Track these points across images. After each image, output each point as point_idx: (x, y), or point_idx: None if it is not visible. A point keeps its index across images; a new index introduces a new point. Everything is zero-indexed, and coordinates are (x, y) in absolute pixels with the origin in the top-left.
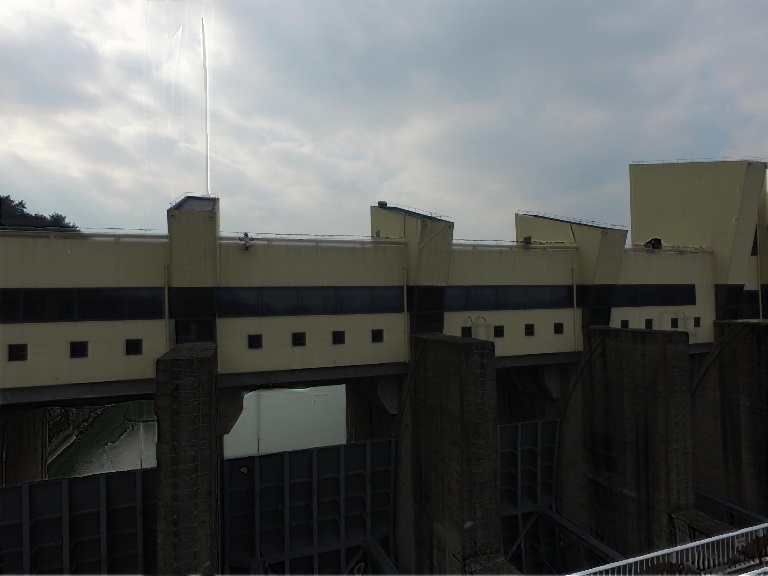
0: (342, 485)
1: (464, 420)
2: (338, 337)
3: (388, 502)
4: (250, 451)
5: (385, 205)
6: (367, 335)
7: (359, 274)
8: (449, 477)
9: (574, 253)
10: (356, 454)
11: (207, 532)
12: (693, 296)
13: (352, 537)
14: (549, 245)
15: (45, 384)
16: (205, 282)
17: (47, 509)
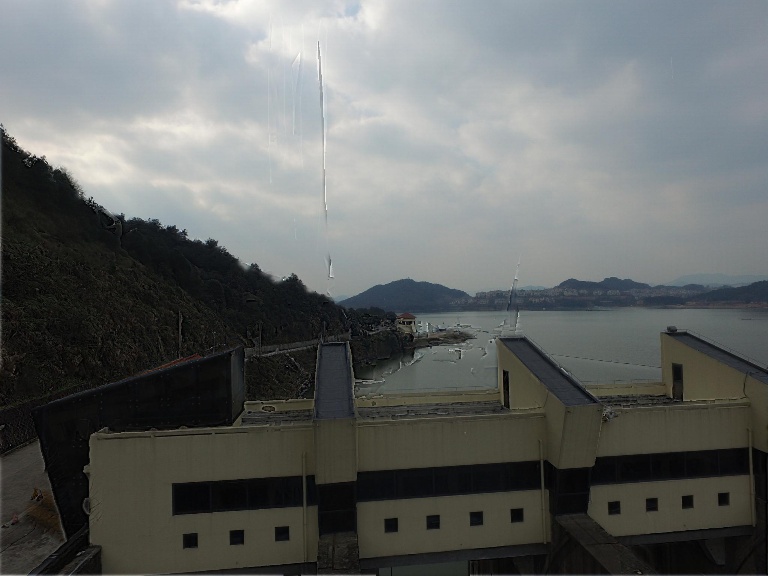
0: None
1: None
2: (686, 501)
3: None
4: None
5: (675, 331)
6: (714, 499)
7: (704, 438)
8: None
9: None
10: None
11: None
12: None
13: None
14: None
15: (453, 549)
16: (585, 463)
17: None
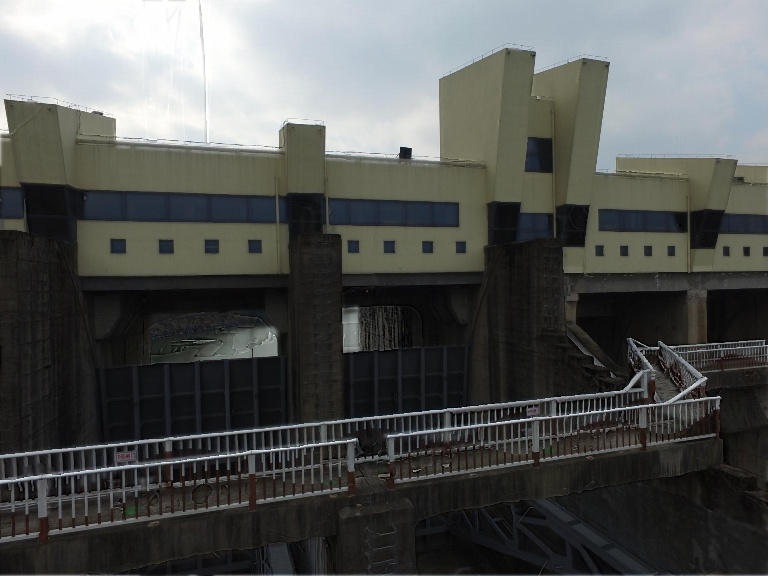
0: None
1: None
2: None
3: None
4: None
5: None
6: None
7: None
8: None
9: (279, 159)
10: None
11: None
12: (456, 217)
13: None
14: (242, 148)
15: None
16: None
17: None
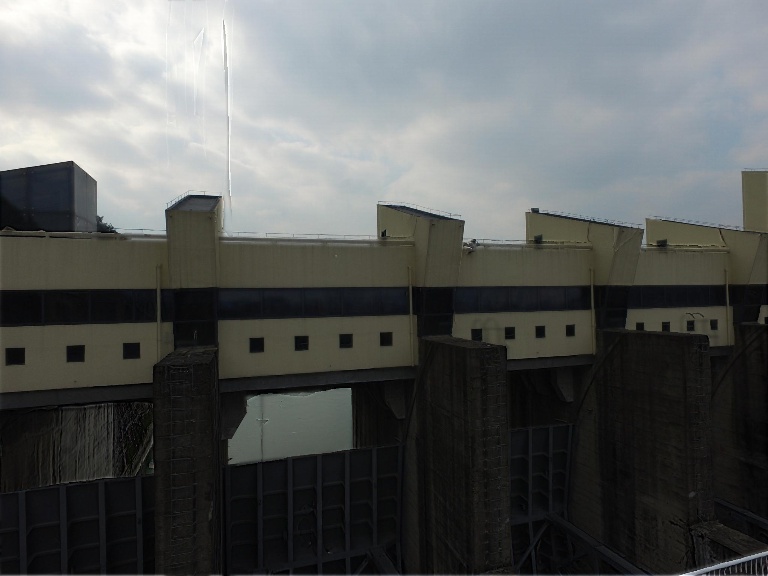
0: (530, 465)
1: (687, 403)
2: (539, 331)
3: (563, 481)
4: (331, 443)
5: (538, 211)
6: (562, 330)
7: (555, 275)
8: (665, 454)
9: (726, 255)
10: (539, 437)
11: (507, 494)
12: None
13: (535, 512)
14: (705, 248)
15: (321, 371)
16: (449, 282)
17: (300, 481)
